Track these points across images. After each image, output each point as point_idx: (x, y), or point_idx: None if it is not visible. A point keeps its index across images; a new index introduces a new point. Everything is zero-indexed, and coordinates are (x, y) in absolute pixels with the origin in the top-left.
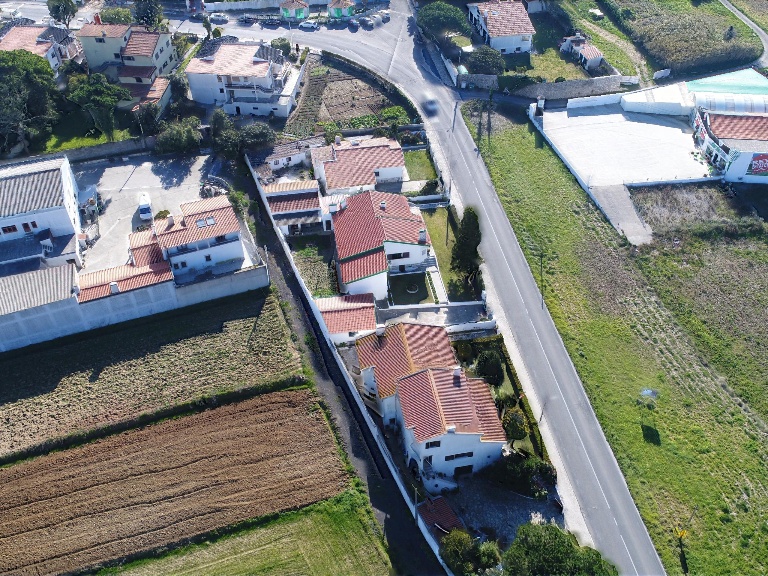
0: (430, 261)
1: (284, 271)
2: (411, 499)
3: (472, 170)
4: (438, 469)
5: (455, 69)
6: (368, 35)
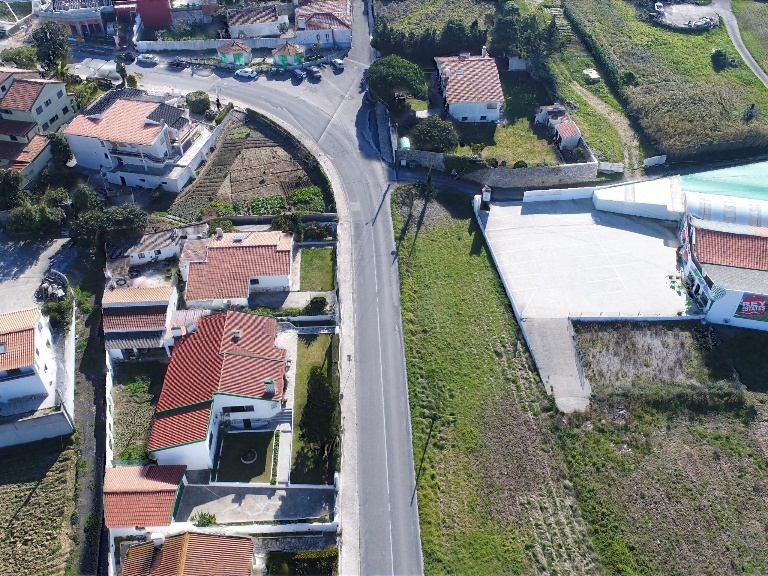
0: (285, 415)
1: (99, 412)
2: None
3: (380, 282)
4: None
5: (395, 142)
6: (311, 89)
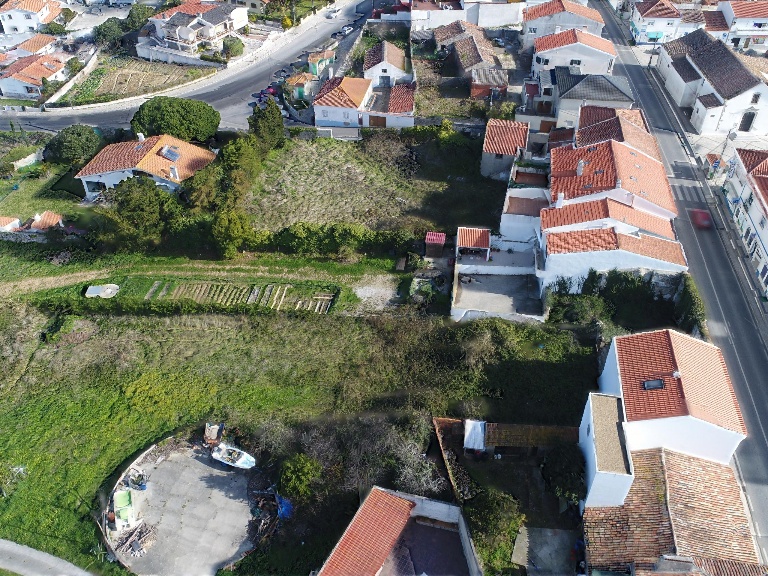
0: None
1: None
2: None
3: None
4: None
5: (94, 125)
6: (240, 102)
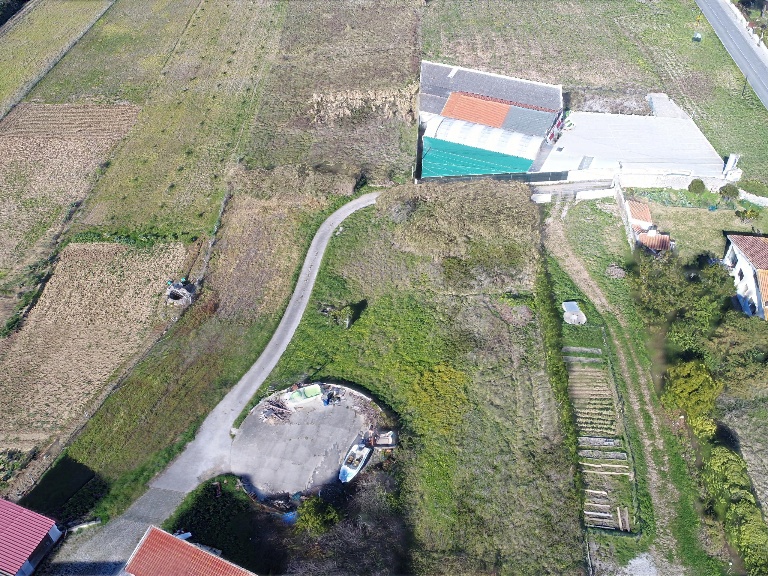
0: None
1: None
2: None
3: None
4: None
5: None
6: None
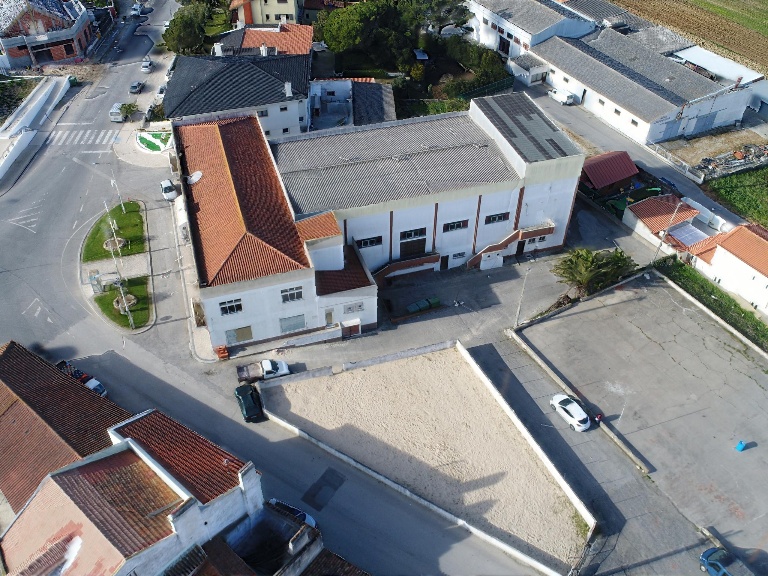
0: None
1: None
2: None
3: None
4: None
5: None
6: None
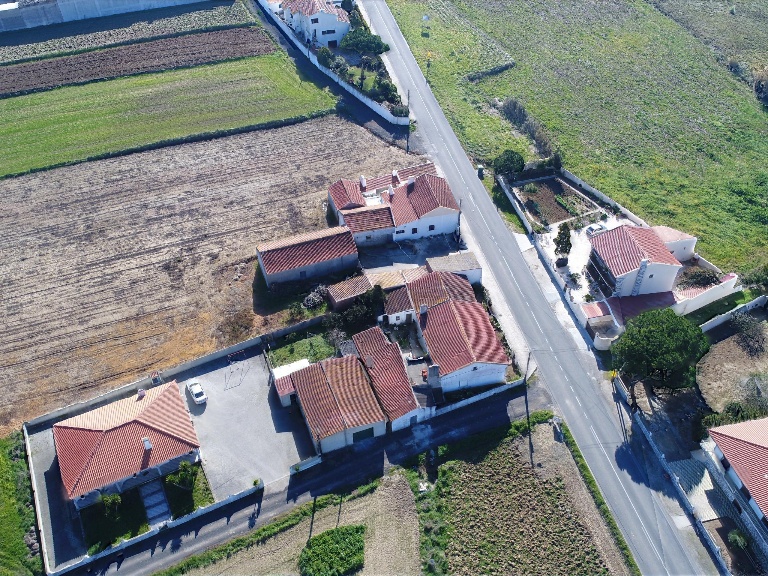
0: None
1: None
2: (306, 47)
3: None
4: (320, 41)
5: None
6: None
